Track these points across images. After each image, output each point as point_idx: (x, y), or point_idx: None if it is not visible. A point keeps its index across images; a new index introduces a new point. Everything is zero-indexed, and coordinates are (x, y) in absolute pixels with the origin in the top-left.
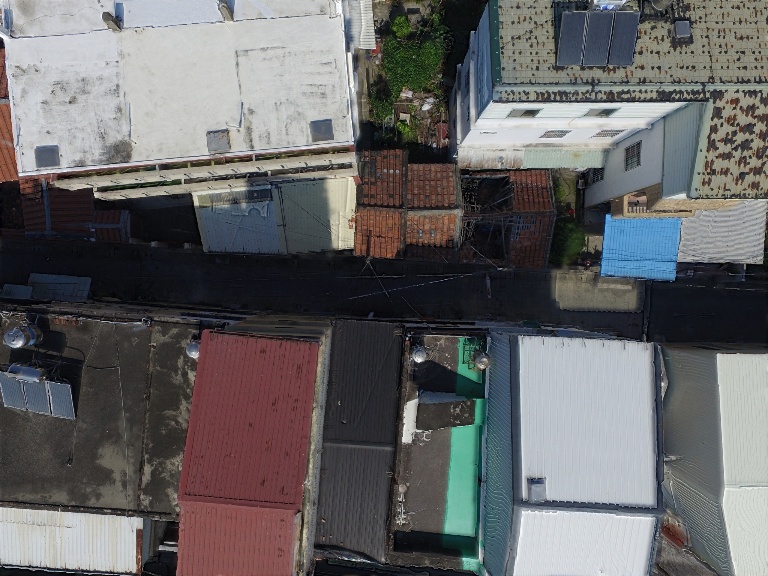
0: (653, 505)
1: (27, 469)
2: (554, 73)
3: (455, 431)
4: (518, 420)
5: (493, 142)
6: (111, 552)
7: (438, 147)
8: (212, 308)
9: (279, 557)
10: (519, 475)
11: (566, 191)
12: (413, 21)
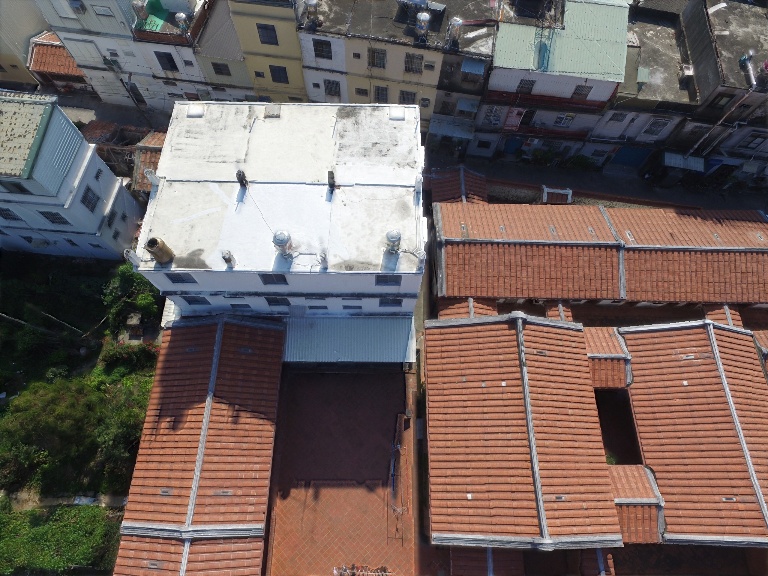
0: None
1: None
2: (3, 109)
3: None
4: None
5: None
6: None
7: None
8: None
9: None
10: None
11: None
12: (136, 318)
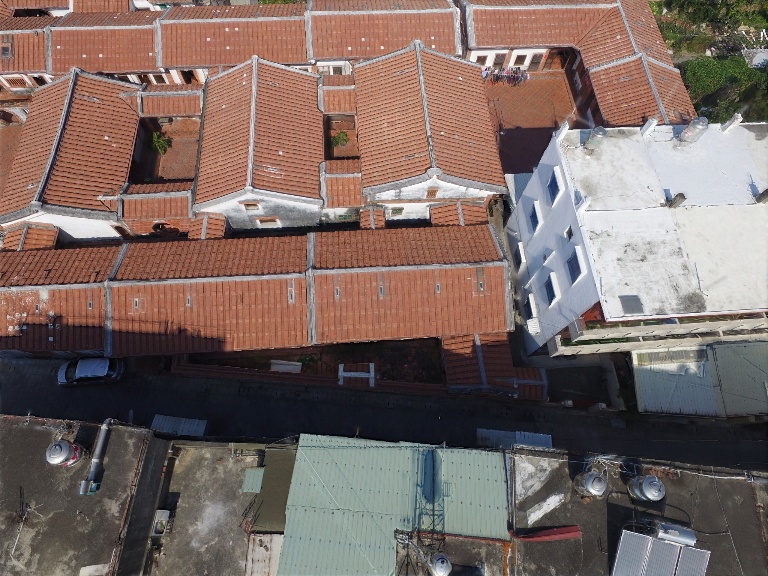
0: None
1: None
2: None
3: None
4: None
5: None
6: None
7: None
8: None
9: None
10: None
11: None
12: None
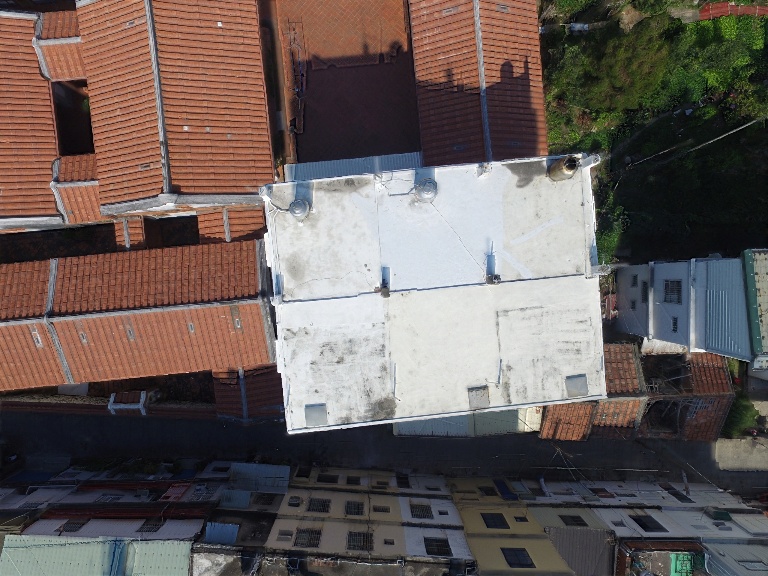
0: None
1: None
2: None
3: None
4: None
5: None
6: None
7: (608, 318)
8: (404, 492)
9: None
10: None
11: (729, 358)
12: None
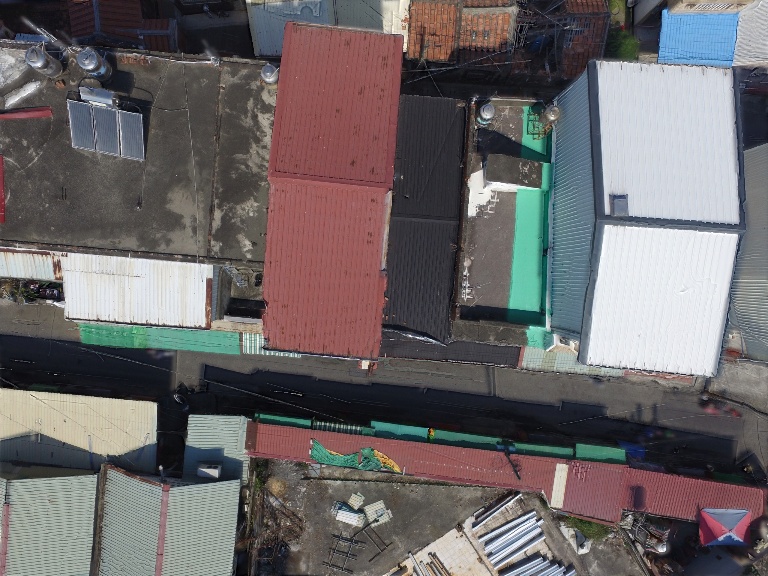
0: (735, 222)
1: (96, 213)
2: None
3: (519, 204)
4: (598, 140)
5: None
6: (180, 304)
7: None
8: None
9: (368, 243)
10: (601, 191)
11: (615, 10)
12: None
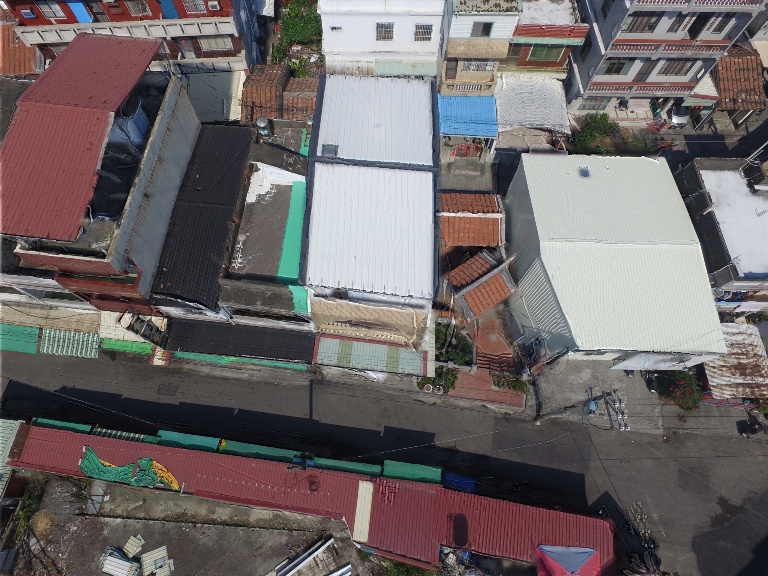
0: (430, 164)
1: None
2: None
3: (294, 194)
4: (319, 114)
5: (347, 49)
6: None
7: None
8: None
9: (88, 150)
10: (315, 142)
11: None
12: None
